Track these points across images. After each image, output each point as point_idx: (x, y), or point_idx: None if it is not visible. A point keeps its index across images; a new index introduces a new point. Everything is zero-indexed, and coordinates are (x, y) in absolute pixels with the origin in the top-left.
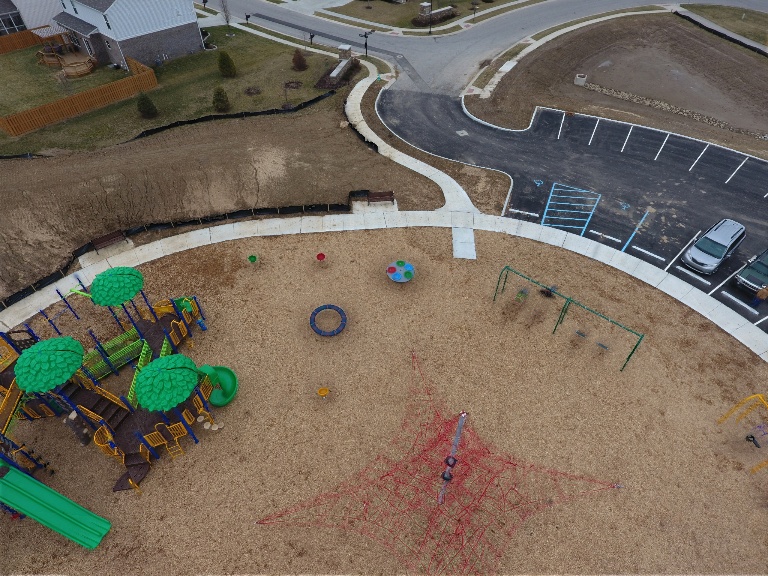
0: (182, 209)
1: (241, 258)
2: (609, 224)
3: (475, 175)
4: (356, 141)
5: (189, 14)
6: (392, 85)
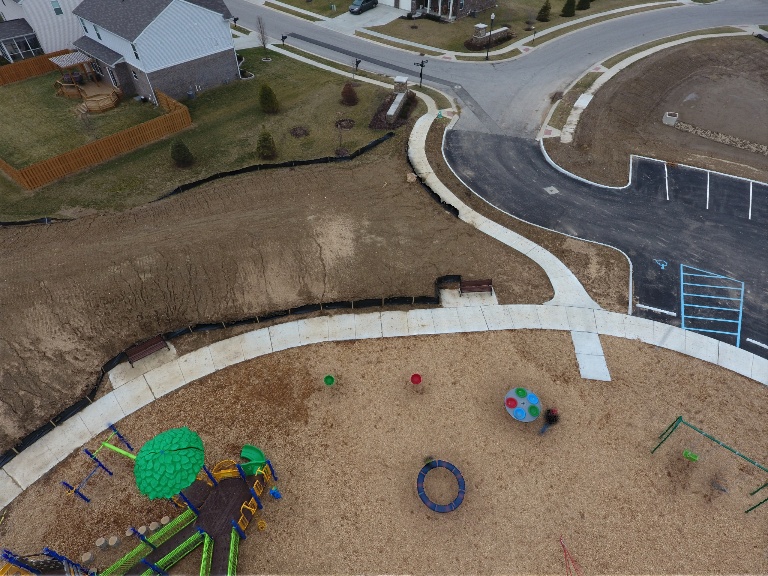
0: (234, 301)
1: (313, 376)
2: (767, 329)
3: (583, 252)
4: (429, 201)
5: (226, 41)
6: (456, 124)
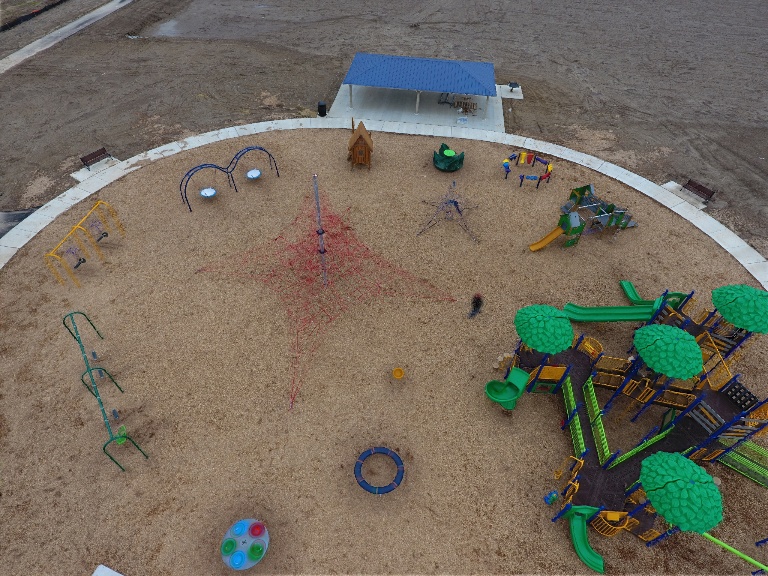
0: None
1: None
2: None
3: None
4: None
5: None
6: None
